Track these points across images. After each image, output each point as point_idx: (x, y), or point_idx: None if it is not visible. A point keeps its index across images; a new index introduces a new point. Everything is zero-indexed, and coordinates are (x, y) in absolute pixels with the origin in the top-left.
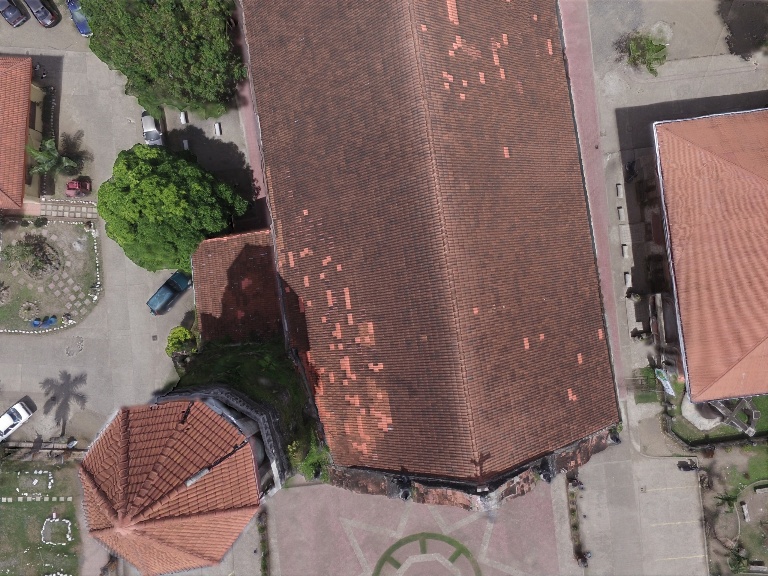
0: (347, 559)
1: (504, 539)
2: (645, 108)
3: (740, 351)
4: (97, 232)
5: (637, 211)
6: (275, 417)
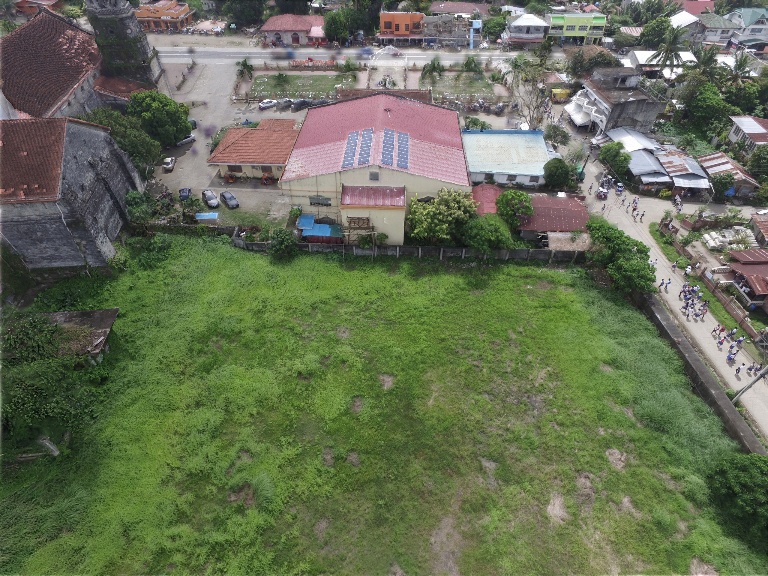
0: None
1: None
2: None
3: None
4: None
5: None
6: None
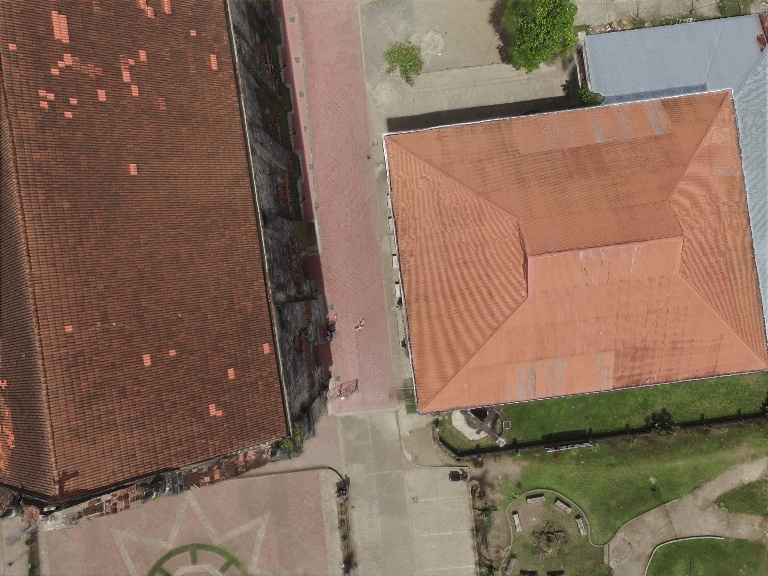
0: (117, 570)
1: (274, 550)
2: (417, 118)
3: (456, 363)
4: None
5: None
6: None
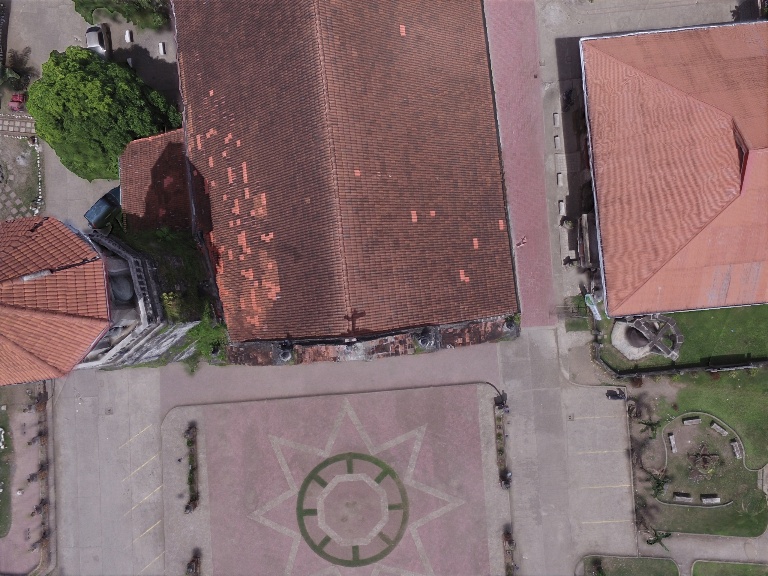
0: (274, 476)
1: (431, 462)
2: None
3: (655, 263)
4: (40, 147)
5: (573, 141)
6: (153, 266)
